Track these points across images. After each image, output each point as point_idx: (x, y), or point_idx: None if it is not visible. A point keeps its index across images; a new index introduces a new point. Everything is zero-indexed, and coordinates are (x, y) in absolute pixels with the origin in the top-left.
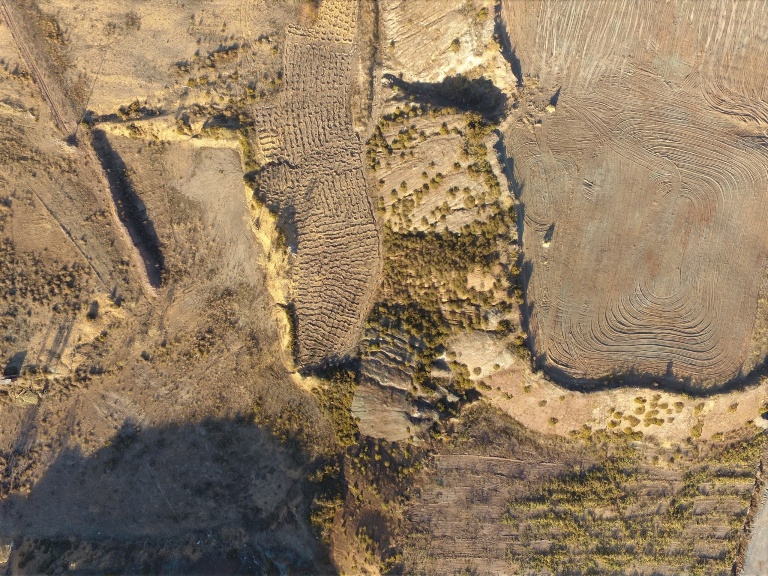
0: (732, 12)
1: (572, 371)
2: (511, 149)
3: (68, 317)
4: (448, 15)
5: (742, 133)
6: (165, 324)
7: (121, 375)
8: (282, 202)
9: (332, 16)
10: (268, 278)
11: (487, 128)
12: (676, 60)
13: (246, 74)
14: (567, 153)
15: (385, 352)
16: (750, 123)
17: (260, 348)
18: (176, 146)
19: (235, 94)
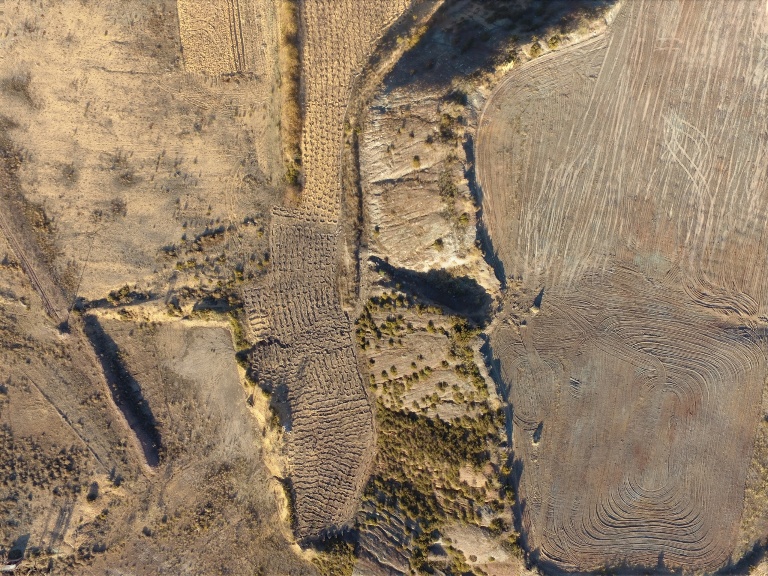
0: (710, 207)
1: (565, 565)
2: (497, 350)
3: (69, 499)
4: (430, 216)
5: (724, 325)
6: (165, 500)
7: (124, 551)
8: (275, 381)
9: (316, 198)
10: (264, 452)
11: (473, 332)
12: (657, 257)
13: (233, 256)
14: (553, 352)
15: (382, 528)
16: (732, 315)
17: (259, 520)
18: (167, 327)
19: (223, 276)
